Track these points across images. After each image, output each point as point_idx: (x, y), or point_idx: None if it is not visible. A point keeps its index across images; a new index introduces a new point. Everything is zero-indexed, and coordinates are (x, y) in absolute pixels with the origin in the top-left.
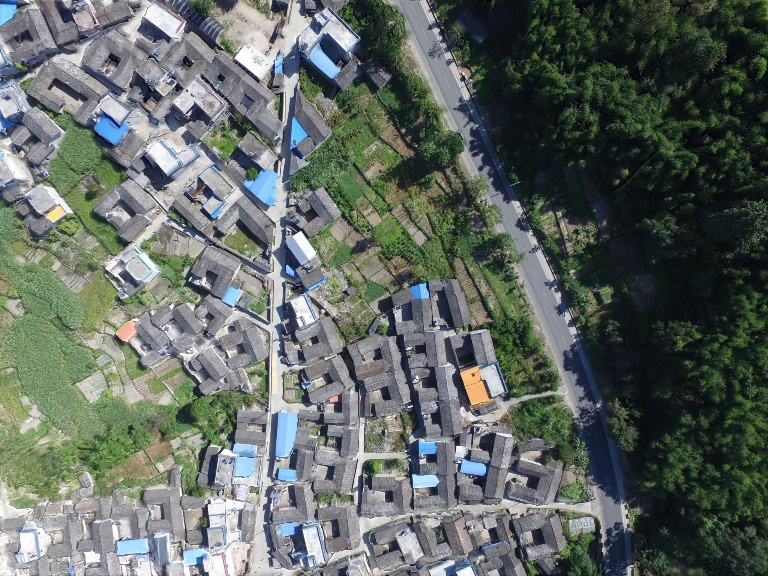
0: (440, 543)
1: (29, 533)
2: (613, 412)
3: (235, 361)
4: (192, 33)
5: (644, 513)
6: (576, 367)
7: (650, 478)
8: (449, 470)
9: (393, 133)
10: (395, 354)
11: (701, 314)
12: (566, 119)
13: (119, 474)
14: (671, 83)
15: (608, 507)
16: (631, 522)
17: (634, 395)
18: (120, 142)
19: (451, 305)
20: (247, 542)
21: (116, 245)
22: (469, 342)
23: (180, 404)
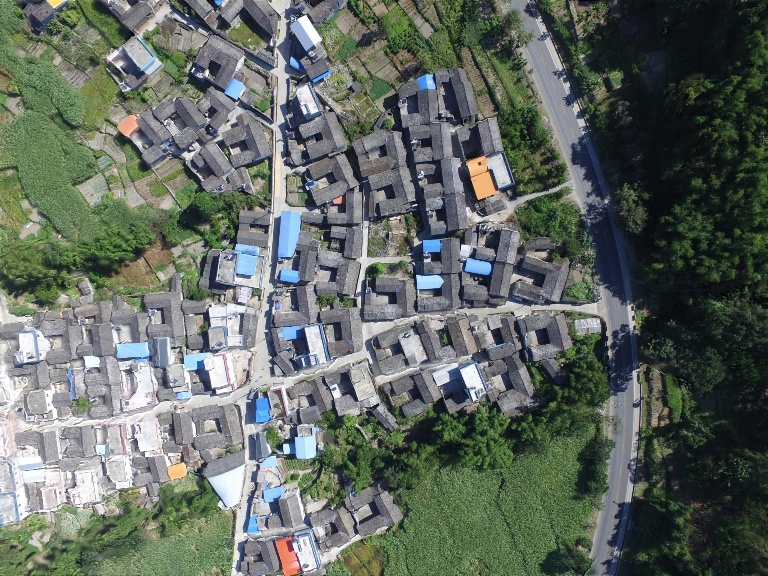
0: (444, 346)
1: (28, 333)
2: (621, 196)
3: (238, 157)
4: None
5: (651, 315)
6: (584, 161)
7: (658, 259)
8: (454, 267)
9: None
10: (400, 150)
11: (714, 69)
12: None
13: (119, 283)
14: None
15: (614, 308)
16: (637, 325)
17: (643, 182)
18: None
19: (458, 94)
20: (248, 346)
21: (118, 37)
22: (476, 131)
23: (182, 207)
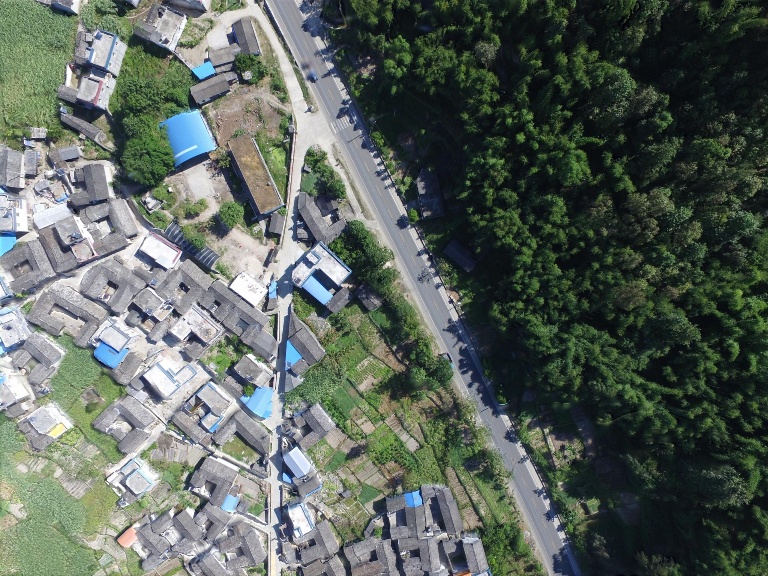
0: None
1: None
2: None
3: (234, 564)
4: (188, 260)
5: None
6: (565, 569)
7: None
8: None
9: (385, 350)
10: (390, 556)
11: (683, 552)
12: (550, 371)
13: None
14: (650, 348)
15: None
16: None
17: None
18: (119, 365)
19: (443, 513)
20: None
21: (116, 454)
22: (461, 550)
23: None
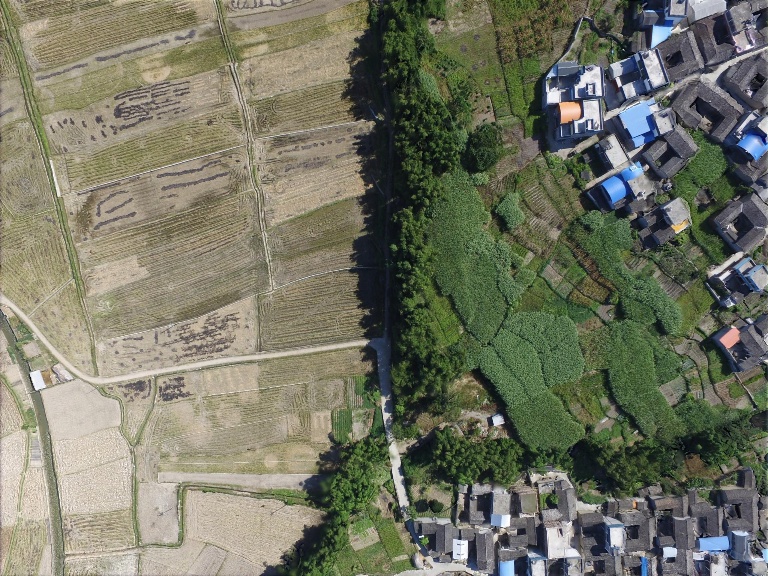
0: None
1: (619, 528)
2: None
3: None
4: None
5: None
6: None
7: None
8: None
9: None
10: None
11: None
12: None
13: (682, 474)
14: None
15: None
16: None
17: None
18: (759, 158)
19: None
20: None
21: (721, 256)
22: None
23: (759, 408)
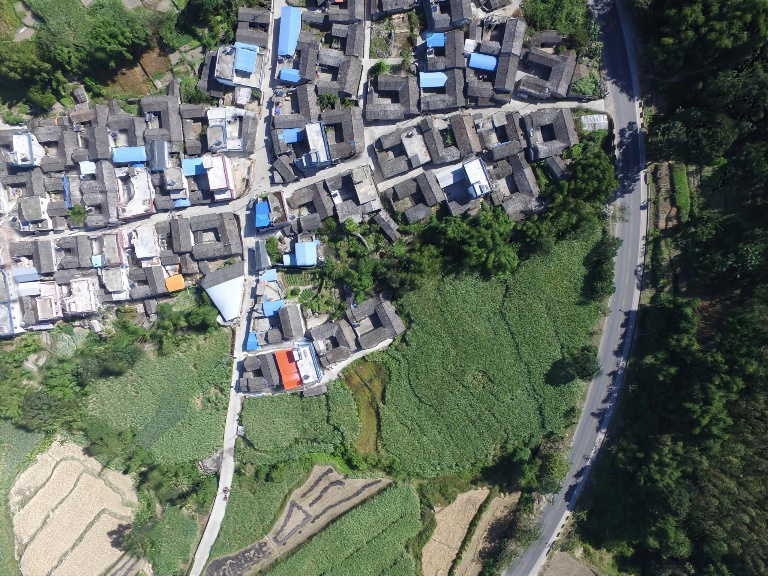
0: (447, 147)
1: (22, 134)
2: None
3: None
4: None
5: (659, 113)
6: None
7: (668, 32)
8: (458, 61)
9: None
10: None
11: None
12: None
13: (116, 93)
14: None
15: (622, 105)
16: (645, 123)
17: None
18: None
19: None
20: (248, 150)
21: None
22: None
23: (179, 9)
